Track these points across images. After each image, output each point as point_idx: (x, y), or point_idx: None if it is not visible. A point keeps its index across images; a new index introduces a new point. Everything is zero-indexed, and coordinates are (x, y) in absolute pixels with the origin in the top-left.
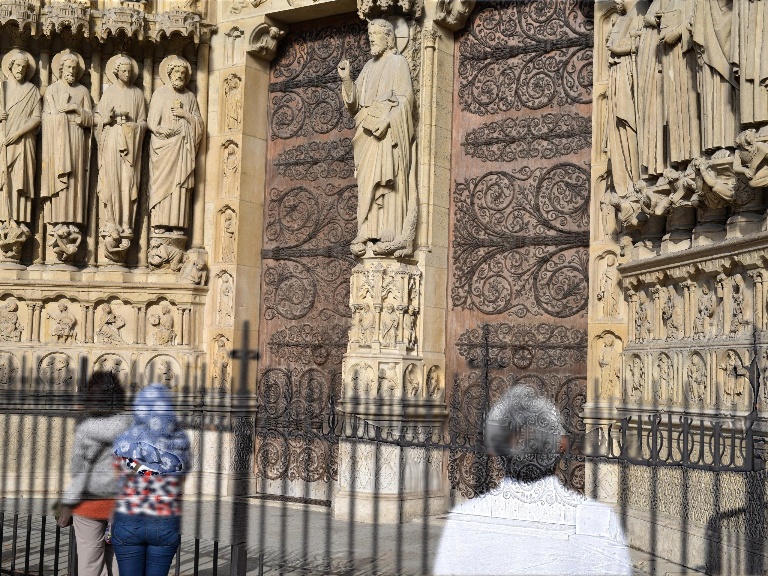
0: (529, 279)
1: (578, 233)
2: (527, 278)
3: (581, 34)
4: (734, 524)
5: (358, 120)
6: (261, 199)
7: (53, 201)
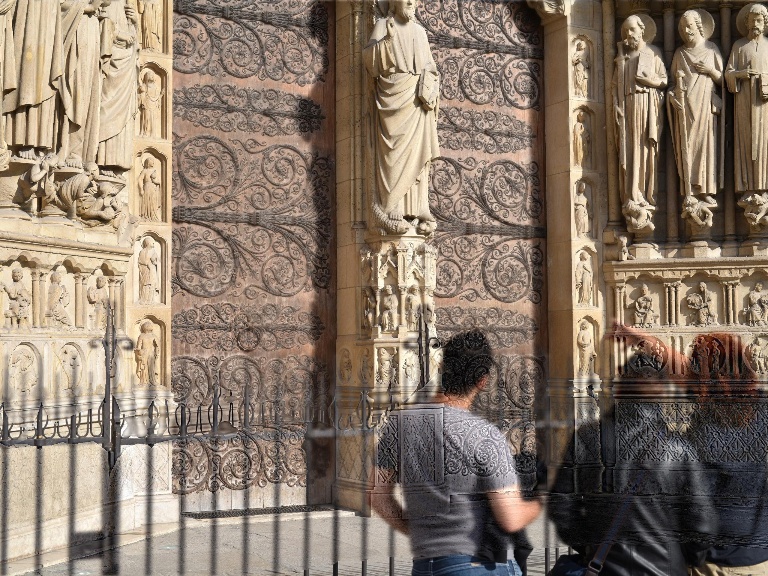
0: (478, 265)
1: (522, 226)
2: (477, 264)
3: (518, 44)
4: None
5: (403, 86)
6: None
7: (33, 113)
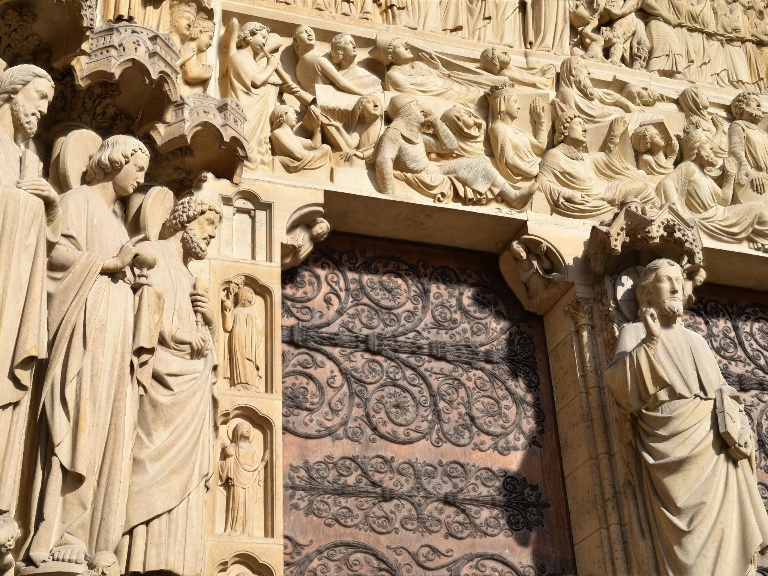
0: None
1: None
2: None
3: None
4: None
5: (688, 419)
6: None
7: None
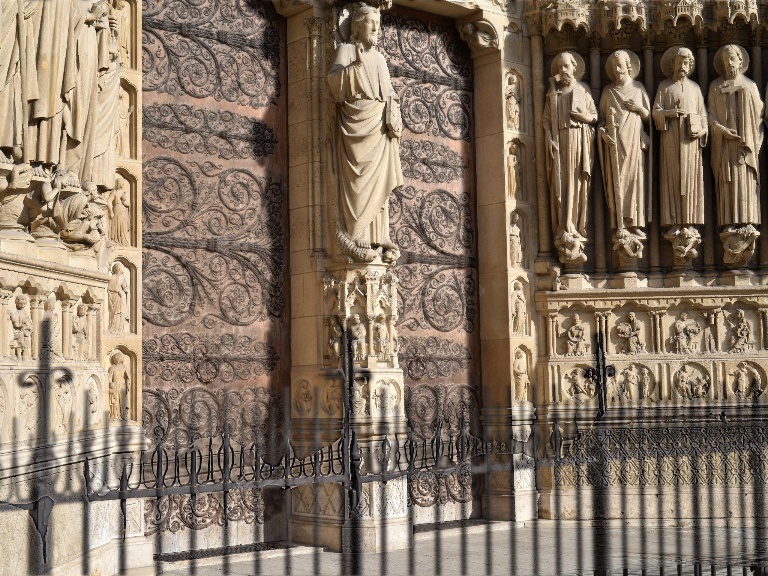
0: (418, 294)
1: (457, 256)
2: None
3: (451, 76)
4: (759, 479)
5: (371, 113)
6: None
7: (44, 126)
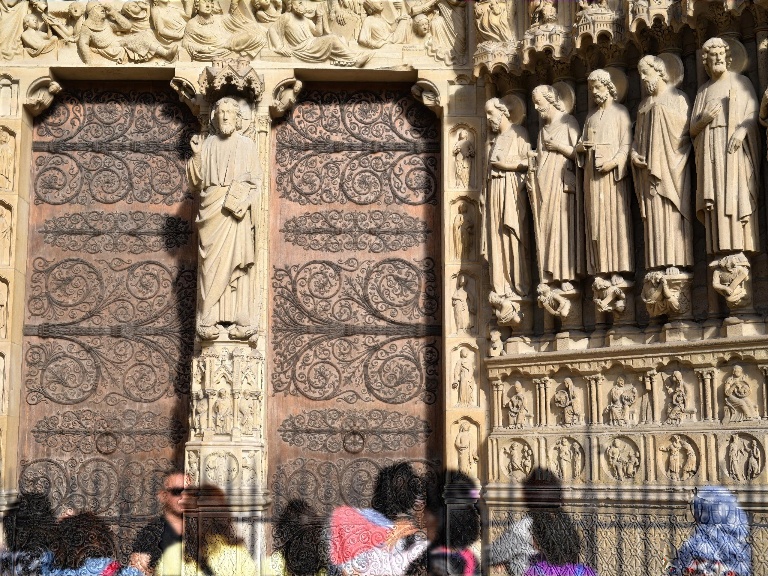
0: (359, 366)
1: (411, 325)
2: (357, 365)
3: (409, 140)
4: None
5: (212, 198)
6: (24, 269)
7: None
